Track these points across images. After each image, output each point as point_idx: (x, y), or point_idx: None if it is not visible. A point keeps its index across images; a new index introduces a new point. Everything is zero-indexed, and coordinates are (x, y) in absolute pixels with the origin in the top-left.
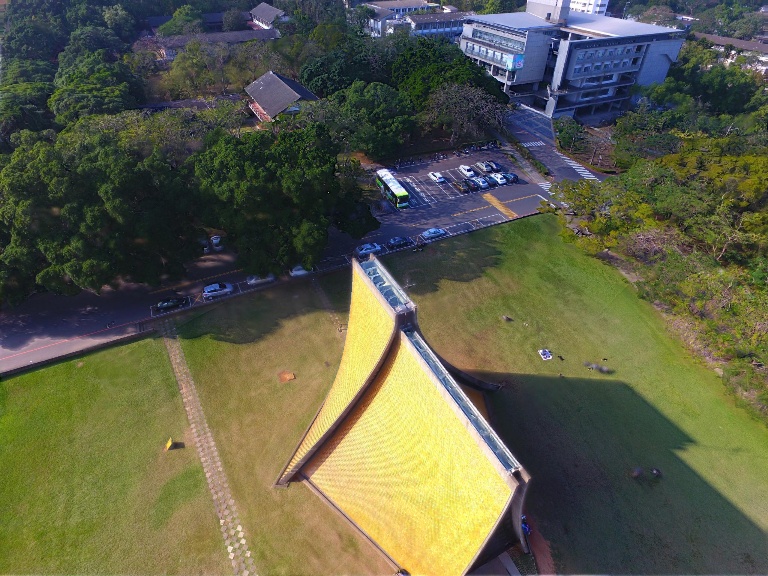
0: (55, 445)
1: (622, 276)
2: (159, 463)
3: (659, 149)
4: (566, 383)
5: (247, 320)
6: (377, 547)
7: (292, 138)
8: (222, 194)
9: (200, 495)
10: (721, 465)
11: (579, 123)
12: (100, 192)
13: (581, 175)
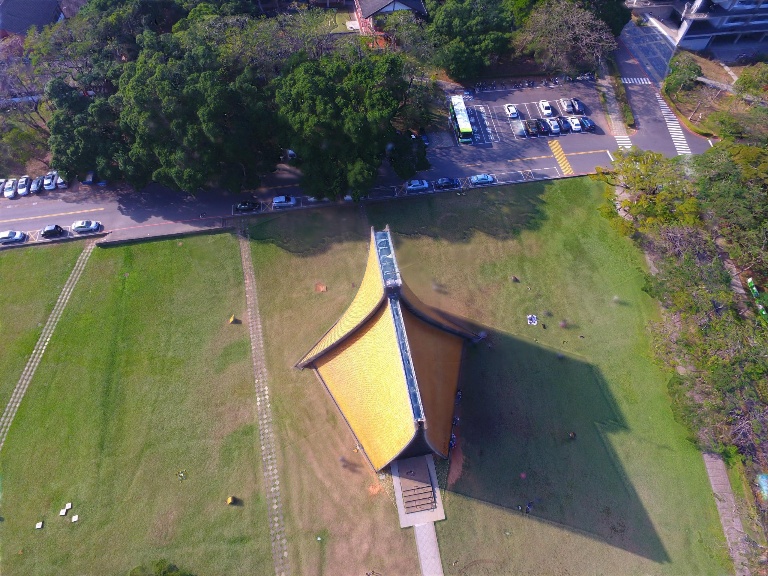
0: (161, 301)
1: (645, 261)
2: (224, 331)
3: (759, 128)
4: (537, 348)
5: (302, 233)
6: (349, 426)
7: (363, 74)
8: (294, 125)
9: (246, 360)
10: (630, 445)
11: (709, 56)
12: (199, 114)
13: (669, 133)
